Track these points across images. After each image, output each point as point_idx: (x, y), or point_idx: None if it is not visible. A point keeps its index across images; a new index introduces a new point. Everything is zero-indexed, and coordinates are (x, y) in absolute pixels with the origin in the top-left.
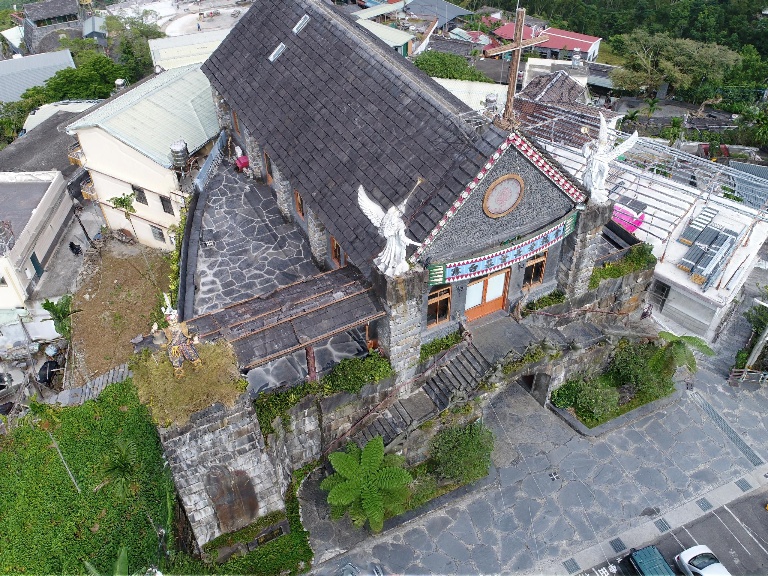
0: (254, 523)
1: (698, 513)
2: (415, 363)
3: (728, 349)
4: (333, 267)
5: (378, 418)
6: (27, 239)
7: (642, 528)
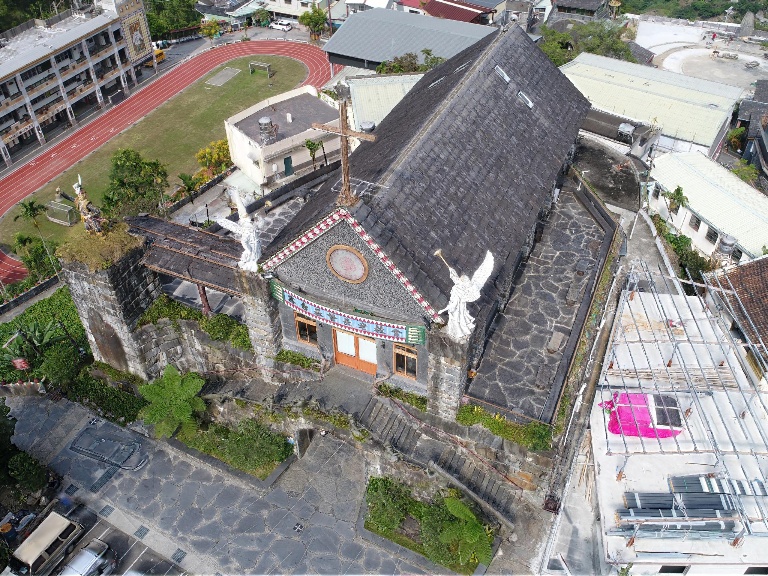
0: (125, 373)
1: None
2: (272, 357)
3: None
4: None
5: (244, 380)
6: (289, 145)
7: None
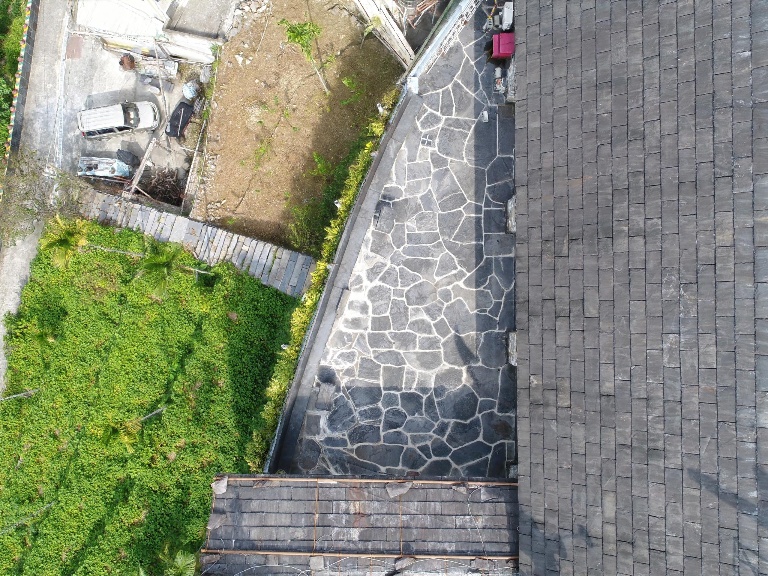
0: None
1: None
2: None
3: None
4: None
5: None
6: None
7: None
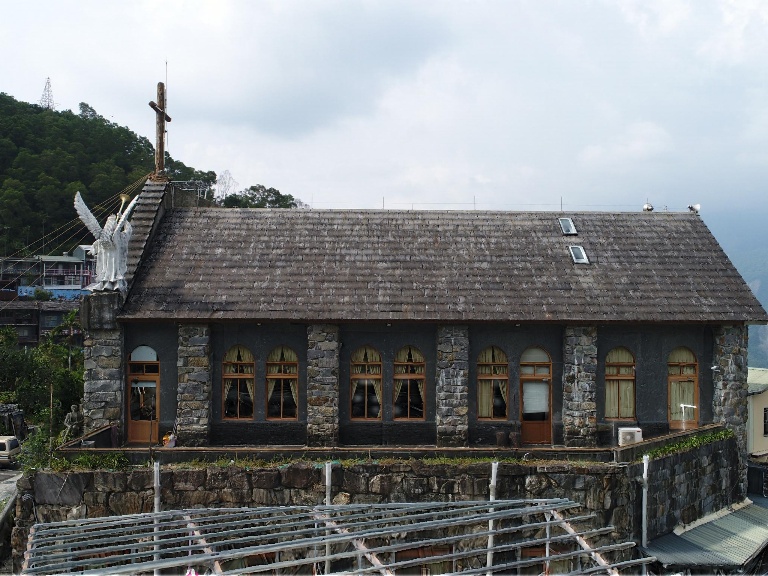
0: None
1: None
2: None
3: None
4: None
5: None
6: None
7: None
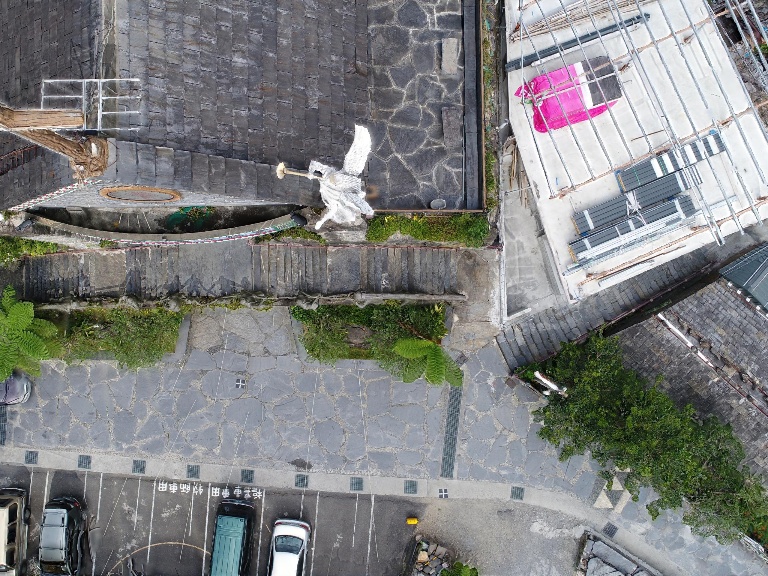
0: None
1: (343, 488)
2: (95, 245)
3: (582, 315)
4: None
5: (73, 255)
6: None
7: (281, 473)
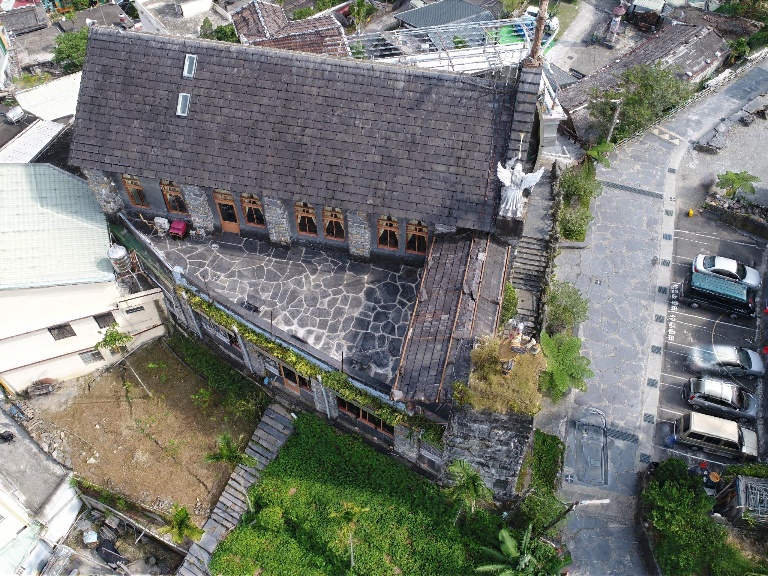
0: None
1: (671, 244)
2: None
3: (566, 145)
4: (387, 252)
5: None
6: None
7: (661, 272)
